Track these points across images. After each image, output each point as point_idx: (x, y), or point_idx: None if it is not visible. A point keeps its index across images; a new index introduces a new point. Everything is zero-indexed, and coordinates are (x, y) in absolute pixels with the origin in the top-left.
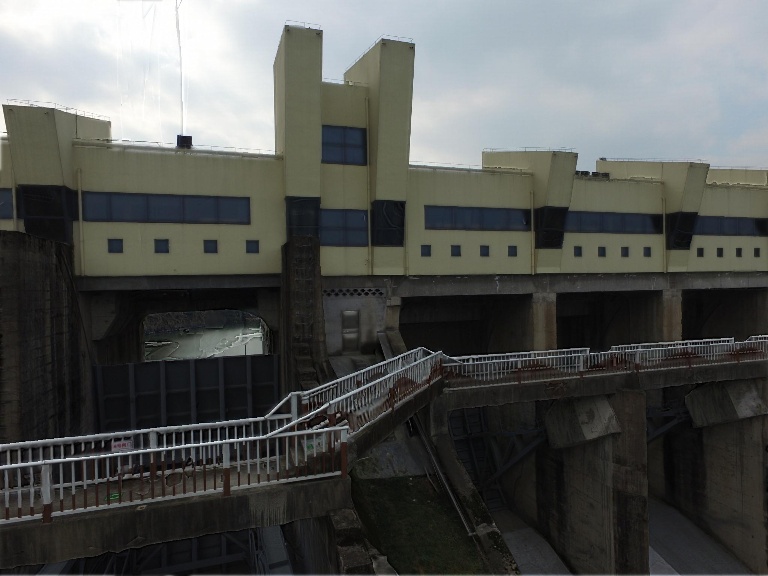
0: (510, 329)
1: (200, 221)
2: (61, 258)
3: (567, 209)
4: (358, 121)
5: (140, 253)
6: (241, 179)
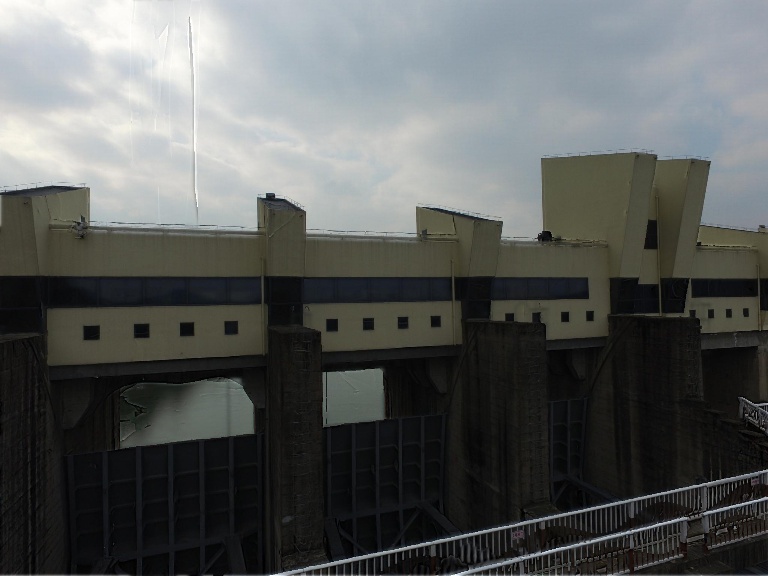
0: (724, 373)
1: (558, 297)
2: None
3: None
4: (651, 214)
5: None
6: (582, 263)
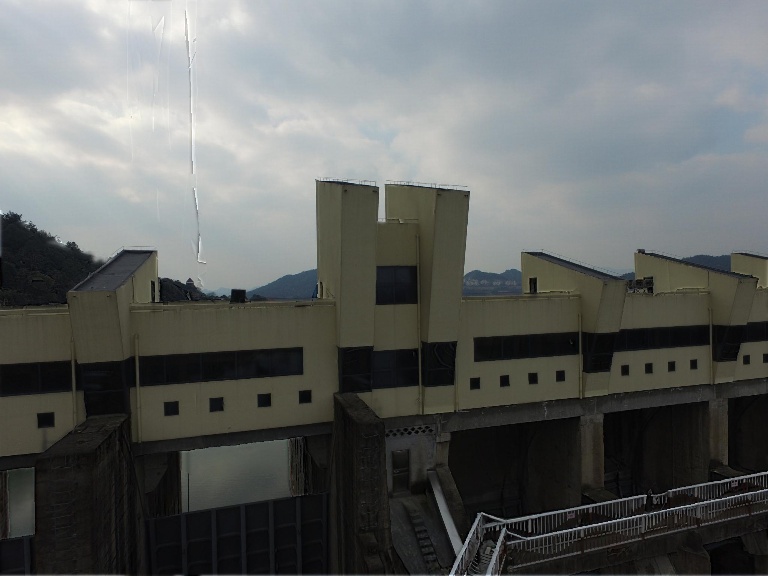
0: (554, 442)
1: (254, 375)
2: (122, 439)
3: (616, 334)
4: (408, 259)
5: (195, 413)
6: (294, 329)
